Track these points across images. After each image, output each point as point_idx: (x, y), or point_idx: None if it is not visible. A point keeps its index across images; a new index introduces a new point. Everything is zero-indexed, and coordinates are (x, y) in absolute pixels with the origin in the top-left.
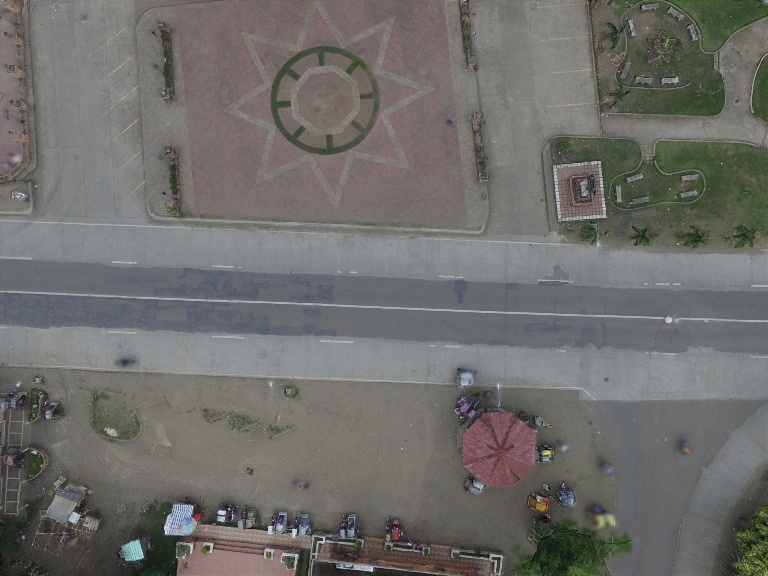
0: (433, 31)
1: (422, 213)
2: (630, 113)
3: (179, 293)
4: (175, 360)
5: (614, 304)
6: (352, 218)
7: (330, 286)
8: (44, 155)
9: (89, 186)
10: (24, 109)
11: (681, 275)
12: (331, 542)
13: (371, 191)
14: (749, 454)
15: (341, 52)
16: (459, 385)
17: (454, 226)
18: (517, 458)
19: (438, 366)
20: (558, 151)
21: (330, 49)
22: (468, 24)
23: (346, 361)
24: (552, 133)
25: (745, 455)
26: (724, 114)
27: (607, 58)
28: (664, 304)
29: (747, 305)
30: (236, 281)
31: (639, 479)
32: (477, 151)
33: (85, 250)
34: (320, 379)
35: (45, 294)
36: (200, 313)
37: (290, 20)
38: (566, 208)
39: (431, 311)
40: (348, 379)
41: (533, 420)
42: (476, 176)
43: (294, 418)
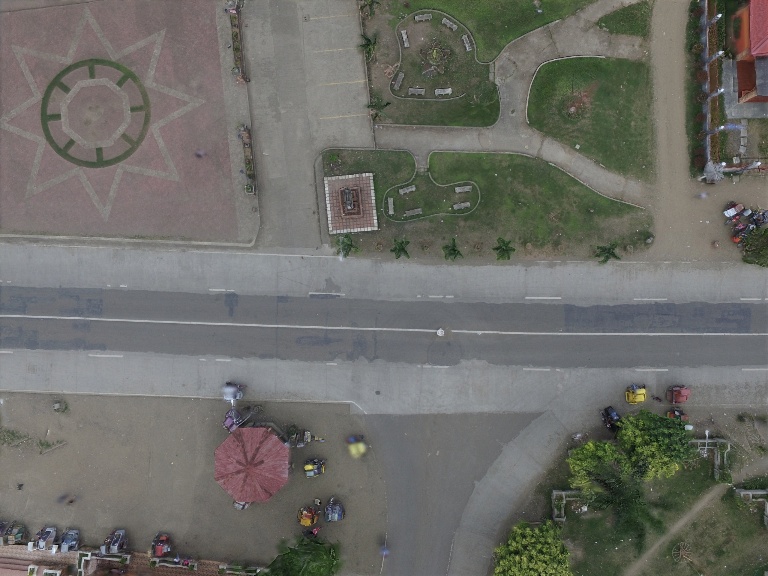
0: (204, 43)
1: (192, 226)
2: (404, 124)
3: None
4: None
5: (386, 317)
6: (121, 232)
7: (99, 300)
8: None
9: None
10: None
11: (454, 287)
12: (97, 558)
13: (141, 204)
14: (523, 468)
15: (112, 65)
16: None
17: (224, 239)
18: (267, 474)
19: (208, 380)
20: (330, 163)
21: (101, 62)
22: (238, 36)
23: (116, 375)
24: (325, 145)
25: (519, 469)
26: (499, 125)
27: (381, 69)
28: (437, 317)
29: (521, 317)
30: (5, 295)
31: (411, 493)
32: (246, 164)
33: None
34: (89, 394)
35: None
36: None
37: (61, 33)
38: (337, 220)
39: (201, 325)
40: (118, 394)
41: (303, 434)
42: None
43: (64, 433)
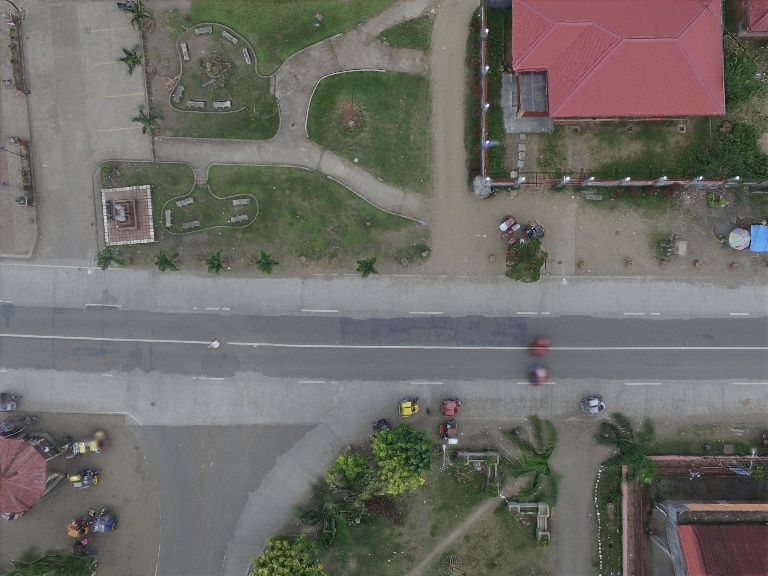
0: None
1: None
2: (183, 137)
3: None
4: None
5: (162, 329)
6: None
7: None
8: None
9: None
10: None
11: (231, 300)
12: None
13: None
14: (296, 480)
15: None
16: None
17: (1, 250)
18: (22, 485)
19: None
20: (108, 175)
21: None
22: (17, 48)
23: None
24: (104, 157)
25: (293, 481)
26: (279, 138)
27: (161, 82)
28: (213, 329)
29: (297, 330)
30: None
31: (184, 505)
32: (22, 175)
33: None
34: None
35: None
36: None
37: None
38: (113, 232)
39: None
40: None
41: None
42: None
43: None
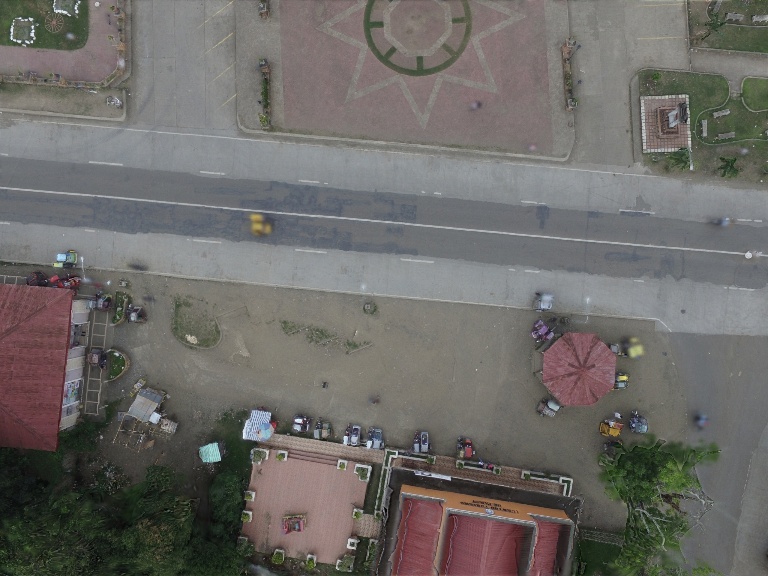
0: None
1: (508, 138)
2: (720, 49)
3: (265, 205)
4: (258, 271)
5: (695, 237)
6: (439, 140)
7: (414, 206)
8: (139, 64)
9: (181, 97)
10: (122, 18)
11: (763, 212)
12: (403, 457)
13: (459, 114)
14: None
15: None
16: (538, 309)
17: (539, 152)
18: (597, 378)
19: (516, 290)
20: (646, 83)
21: None
22: None
23: (426, 281)
24: (641, 65)
25: None
26: None
27: None
28: (745, 240)
29: None
30: (321, 196)
31: (711, 412)
32: (566, 79)
33: (175, 159)
34: (399, 297)
35: (134, 200)
36: (284, 226)
37: None
38: (652, 140)
39: (512, 235)
40: (427, 298)
41: (609, 348)
42: (563, 104)
43: (371, 334)
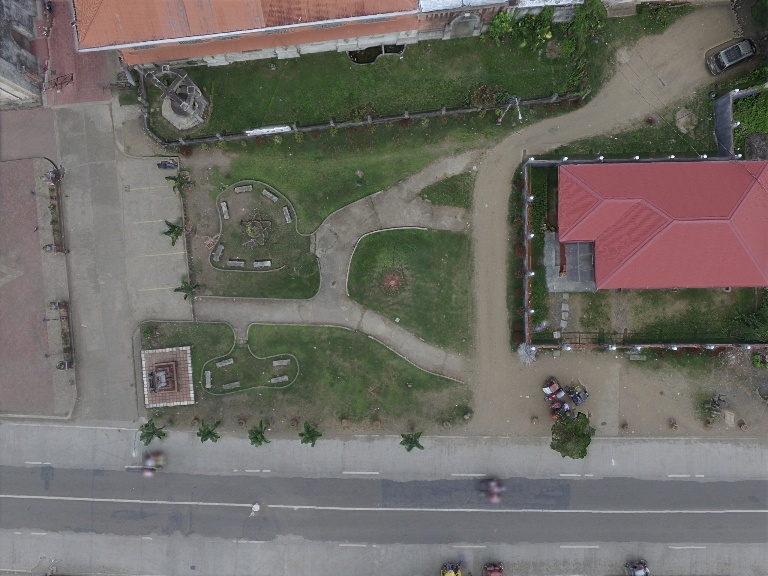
0: (23, 214)
1: (8, 399)
2: (223, 296)
3: None
4: None
5: (202, 491)
6: None
7: None
8: None
9: None
10: None
11: (271, 462)
12: None
13: None
14: None
15: None
16: None
17: (41, 412)
18: None
19: (23, 554)
20: None
21: None
22: (56, 208)
23: None
24: (143, 317)
25: None
26: (320, 297)
27: (201, 240)
28: (253, 491)
29: (338, 492)
30: None
31: None
32: (62, 338)
33: None
34: None
35: None
36: None
37: None
38: (153, 394)
39: (17, 498)
40: None
41: None
42: None
43: None
